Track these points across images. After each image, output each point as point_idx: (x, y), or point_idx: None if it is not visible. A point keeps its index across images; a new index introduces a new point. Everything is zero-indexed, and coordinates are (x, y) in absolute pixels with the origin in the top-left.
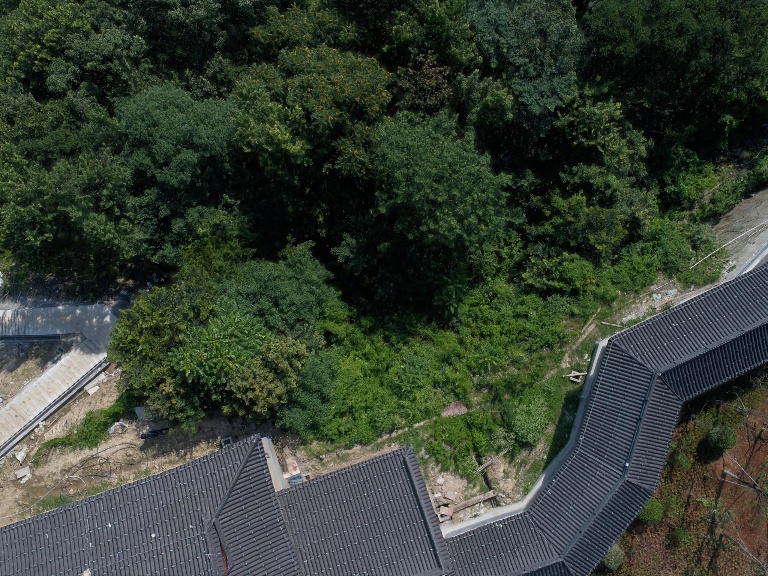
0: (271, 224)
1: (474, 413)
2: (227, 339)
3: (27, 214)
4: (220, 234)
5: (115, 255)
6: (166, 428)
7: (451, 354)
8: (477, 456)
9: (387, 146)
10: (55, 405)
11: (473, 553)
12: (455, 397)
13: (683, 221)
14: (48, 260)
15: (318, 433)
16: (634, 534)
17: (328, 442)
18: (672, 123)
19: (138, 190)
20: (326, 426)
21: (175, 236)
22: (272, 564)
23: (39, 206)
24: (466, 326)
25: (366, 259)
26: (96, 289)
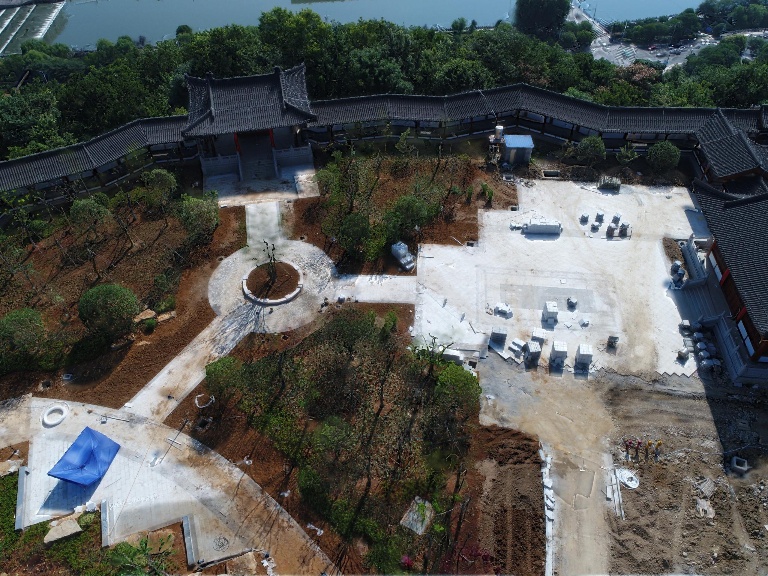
0: None
1: None
2: None
3: None
4: None
5: None
6: None
7: None
8: None
9: None
10: None
11: None
12: None
13: None
14: None
15: None
16: None
17: None
18: None
19: None
20: None
21: None
22: None
23: None
24: None
25: None
26: None
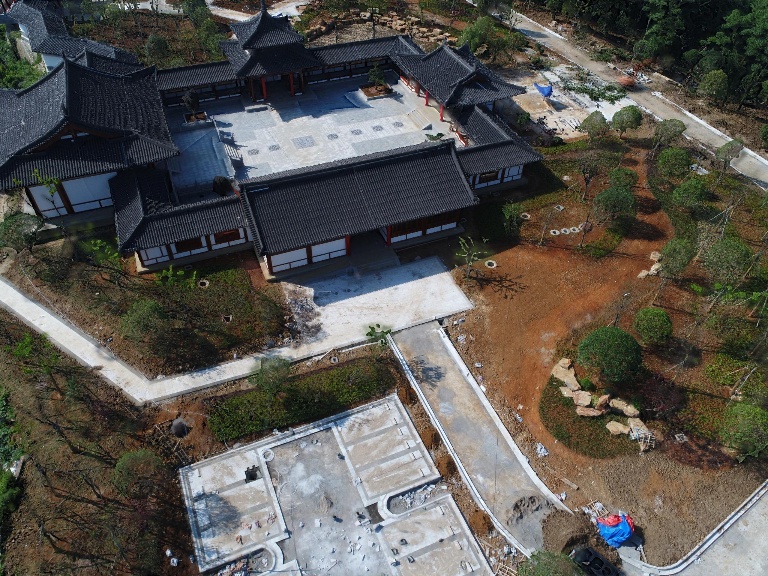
0: None
1: None
2: None
3: None
4: None
5: None
6: None
7: None
8: None
9: None
10: None
11: None
12: None
13: None
14: None
15: None
16: None
17: None
18: None
19: None
20: None
21: None
22: None
23: None
24: None
25: None
26: None
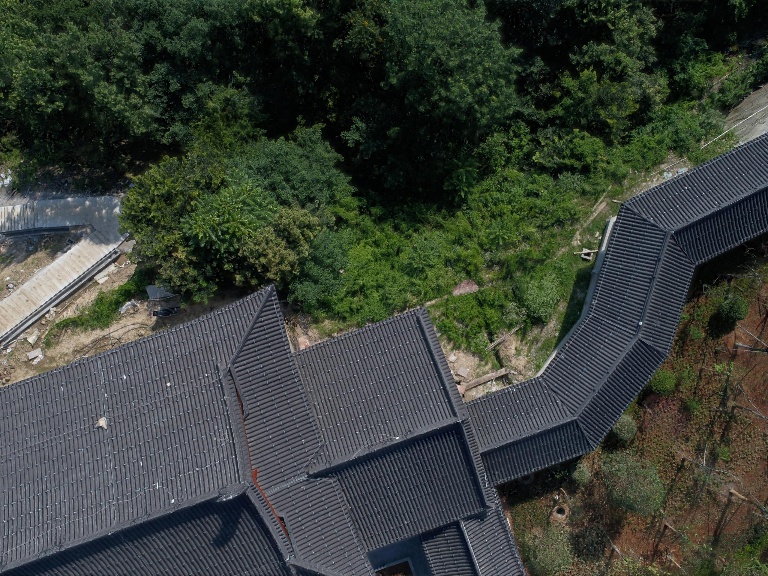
0: (280, 111)
1: (486, 290)
2: (239, 204)
3: (38, 78)
4: (230, 111)
5: (125, 133)
6: (178, 307)
7: (462, 234)
8: (489, 334)
9: (398, 10)
10: (65, 293)
11: (487, 416)
12: (466, 276)
13: (692, 111)
14: (57, 145)
15: (330, 312)
16: (646, 409)
17: (340, 321)
18: (681, 6)
19: (148, 68)
20: (338, 304)
21: (185, 113)
22: (287, 415)
23: (50, 69)
24: (476, 211)
25: (376, 144)
26: (105, 182)
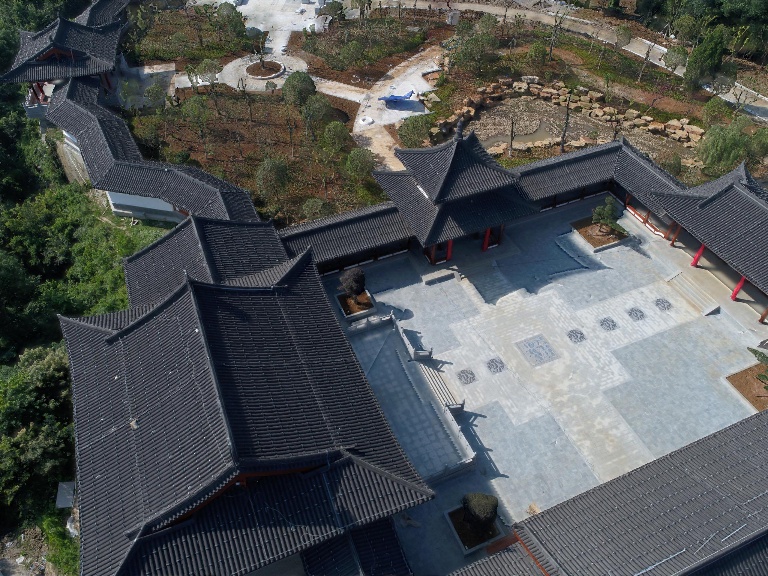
0: None
1: None
2: None
3: None
4: None
5: None
6: None
7: (99, 287)
8: None
9: None
10: None
11: None
12: None
13: None
14: None
15: None
16: None
17: None
18: None
19: None
20: None
21: None
22: None
23: None
24: None
25: None
26: None
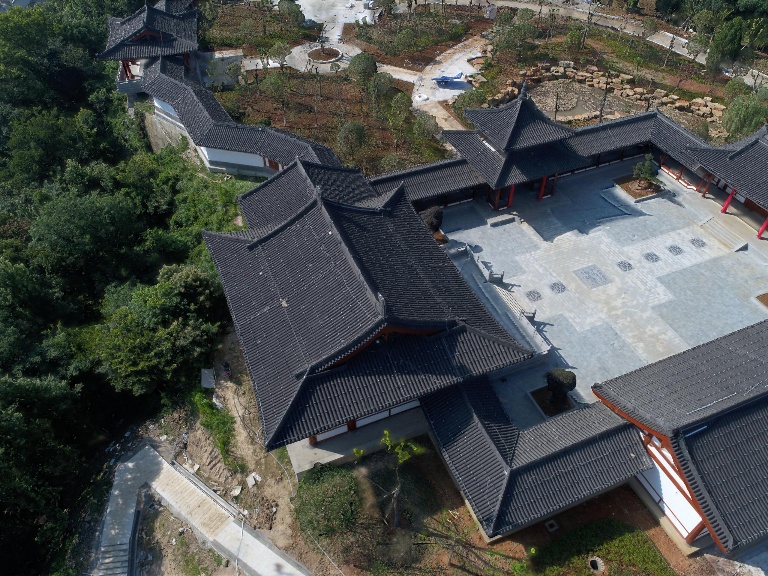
0: None
1: None
2: None
3: None
4: None
5: None
6: None
7: (204, 228)
8: None
9: None
10: None
11: None
12: None
13: None
14: None
15: None
16: None
17: None
18: None
19: None
20: None
21: None
22: None
23: None
24: None
25: None
26: None
